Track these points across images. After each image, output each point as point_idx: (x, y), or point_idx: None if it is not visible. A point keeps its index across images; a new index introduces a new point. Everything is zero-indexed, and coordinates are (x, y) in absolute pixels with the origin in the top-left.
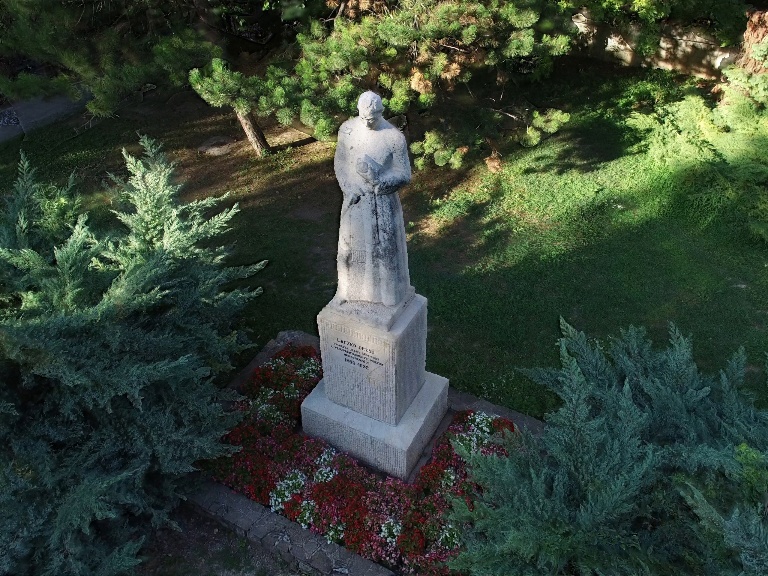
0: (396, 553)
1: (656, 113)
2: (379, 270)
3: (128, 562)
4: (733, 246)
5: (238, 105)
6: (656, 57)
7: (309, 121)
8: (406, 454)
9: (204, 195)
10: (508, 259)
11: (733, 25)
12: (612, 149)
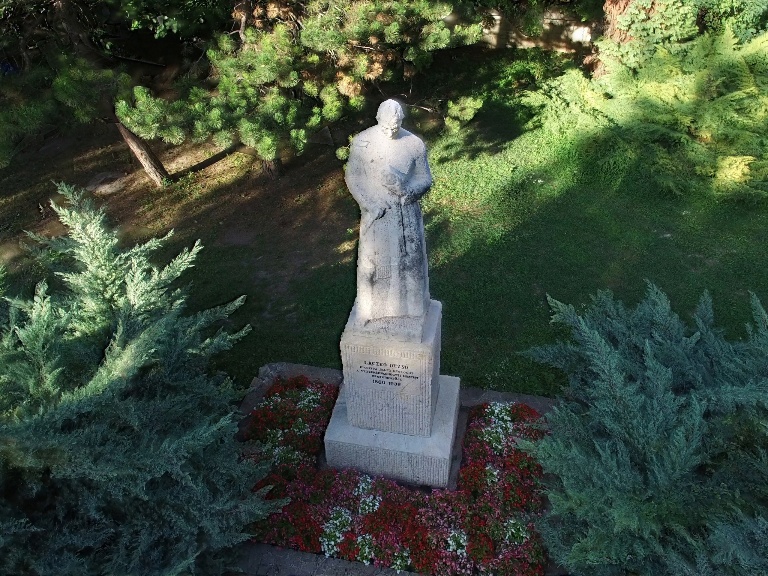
0: (470, 563)
1: (542, 89)
2: (405, 283)
3: None
4: (646, 201)
5: (171, 134)
6: (519, 37)
7: (251, 141)
8: (448, 462)
9: (145, 238)
10: (456, 249)
11: (593, 0)
12: (511, 128)
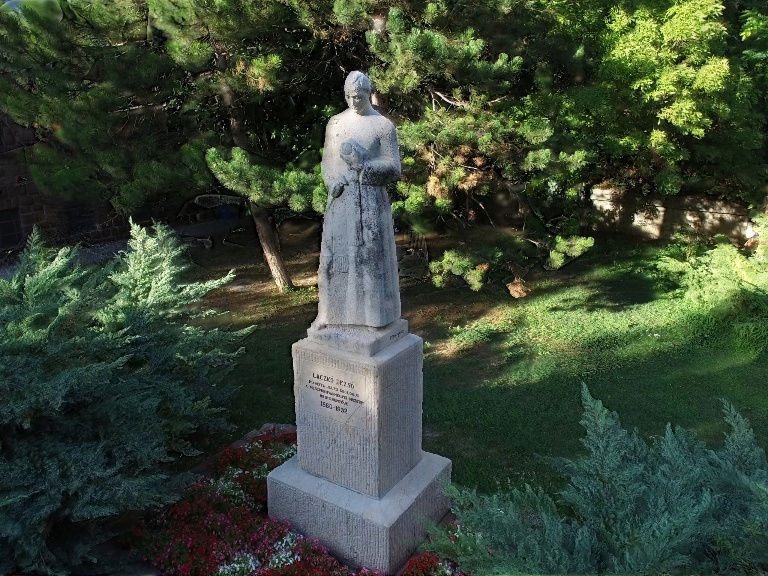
0: None
1: (688, 262)
2: (363, 281)
3: None
4: None
5: (251, 188)
6: None
7: (320, 206)
8: (388, 533)
9: (206, 278)
10: (532, 377)
11: (756, 182)
12: (645, 295)
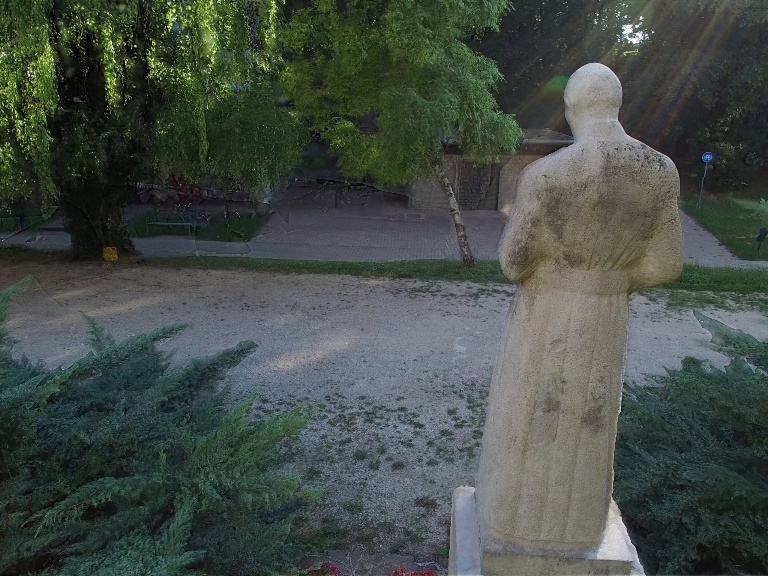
0: None
1: None
2: None
3: None
4: None
5: None
6: None
7: None
8: None
9: None
10: None
11: None
12: None
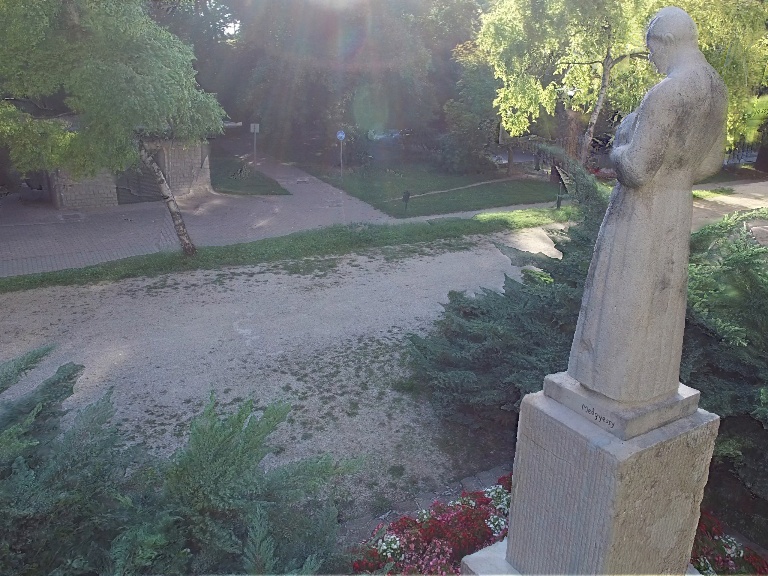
0: None
1: None
2: None
3: (459, 376)
4: None
5: None
6: None
7: None
8: None
9: None
10: None
11: None
12: None
